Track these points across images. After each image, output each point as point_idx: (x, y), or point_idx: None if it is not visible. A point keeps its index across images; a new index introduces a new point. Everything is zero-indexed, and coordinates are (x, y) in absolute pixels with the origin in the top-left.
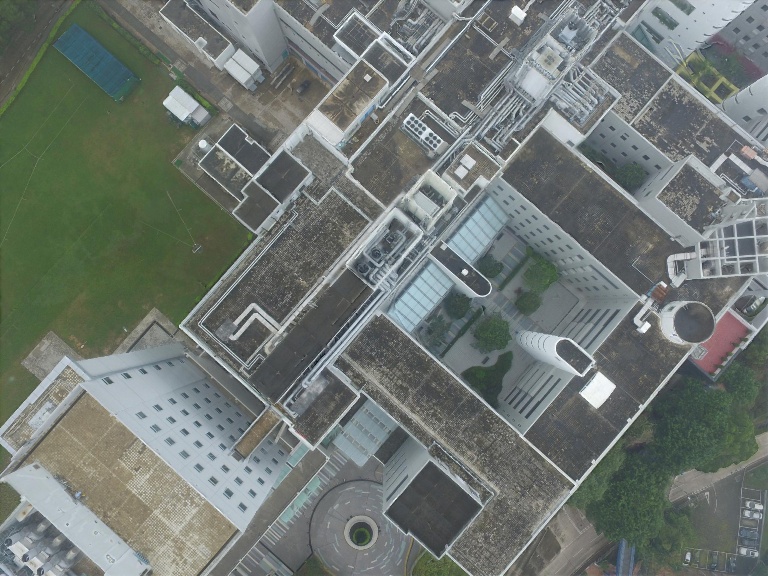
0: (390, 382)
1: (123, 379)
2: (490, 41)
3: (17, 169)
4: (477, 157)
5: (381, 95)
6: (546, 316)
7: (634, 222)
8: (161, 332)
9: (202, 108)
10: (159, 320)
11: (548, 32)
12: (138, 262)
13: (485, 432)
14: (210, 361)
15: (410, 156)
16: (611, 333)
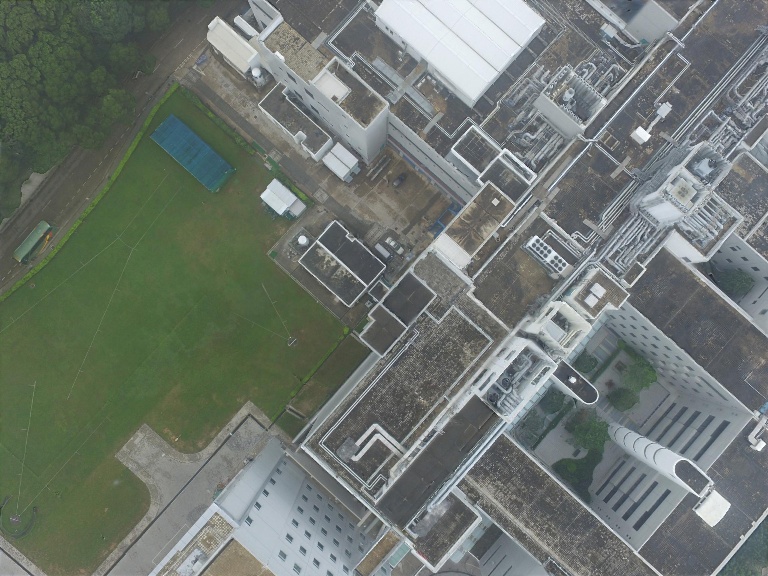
0: (504, 497)
1: (257, 512)
2: (612, 160)
3: (111, 259)
4: (605, 284)
5: (507, 218)
6: (636, 408)
7: (747, 337)
8: (256, 425)
9: (299, 201)
10: (254, 413)
11: (683, 165)
12: (233, 355)
13: (599, 548)
14: (304, 455)
15: (531, 275)
16: (725, 450)
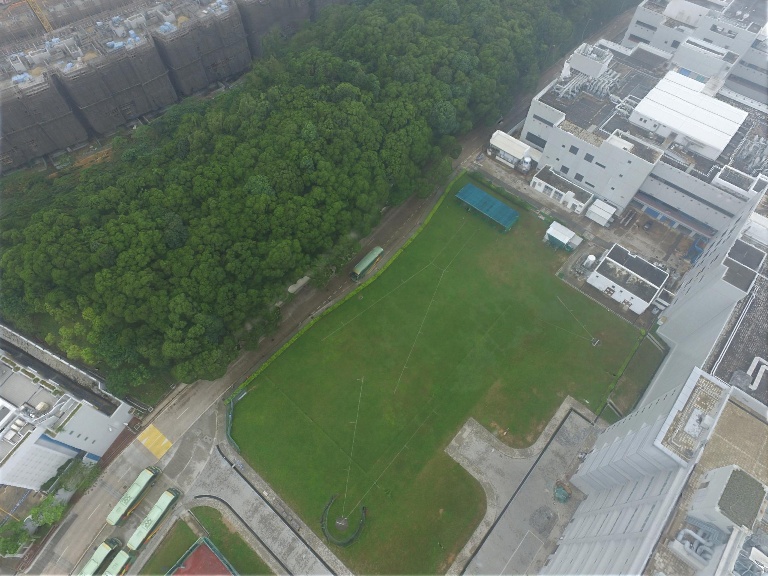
0: None
1: None
2: None
3: (426, 278)
4: None
5: None
6: None
7: None
8: (580, 420)
9: (577, 236)
10: (576, 407)
11: None
12: (544, 353)
13: None
14: None
15: None
16: None
